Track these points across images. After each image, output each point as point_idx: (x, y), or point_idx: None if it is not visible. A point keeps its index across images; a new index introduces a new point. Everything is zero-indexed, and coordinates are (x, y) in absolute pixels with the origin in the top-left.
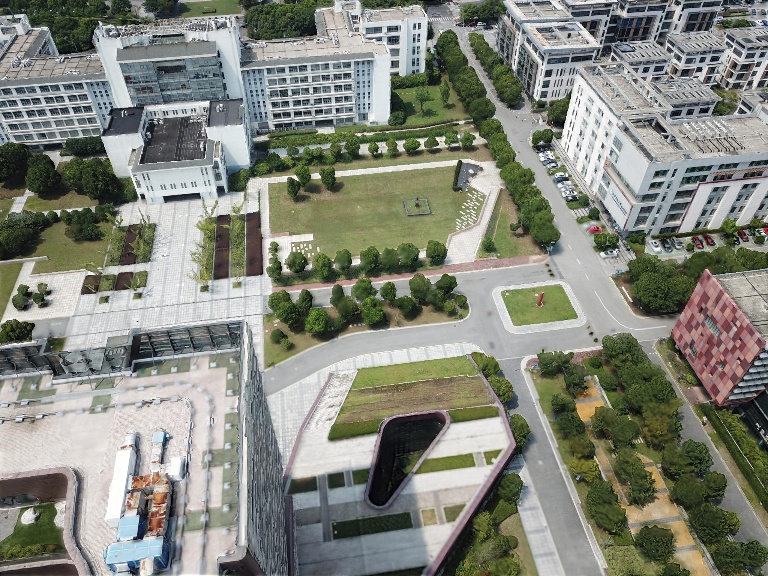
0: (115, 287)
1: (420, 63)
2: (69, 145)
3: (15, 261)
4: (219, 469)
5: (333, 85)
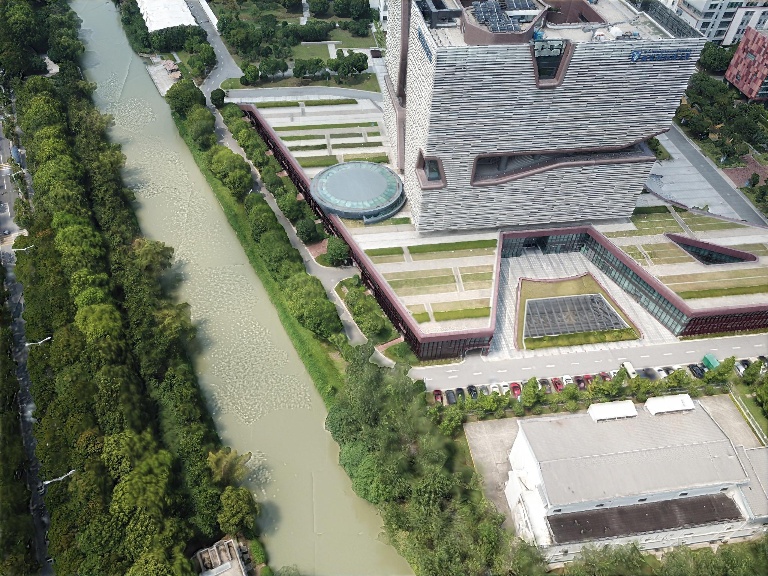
0: None
1: None
2: None
3: (323, 43)
4: None
5: None
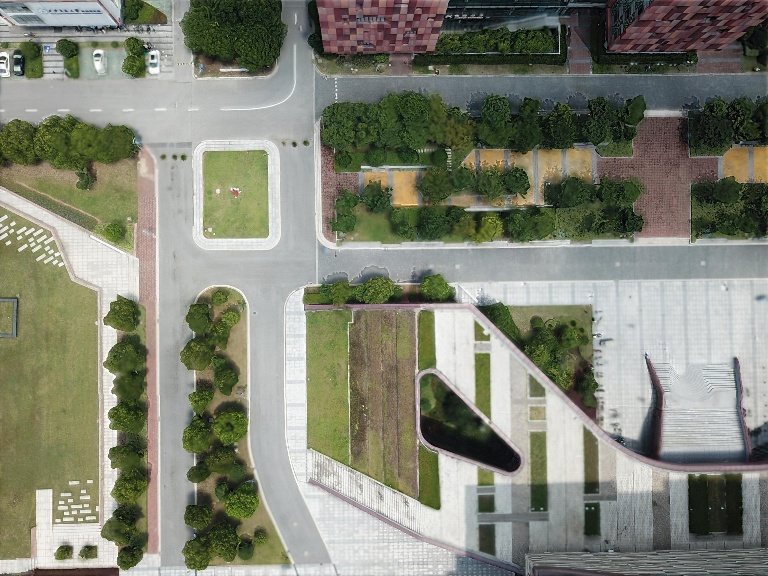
0: None
1: None
2: None
3: None
4: None
5: None
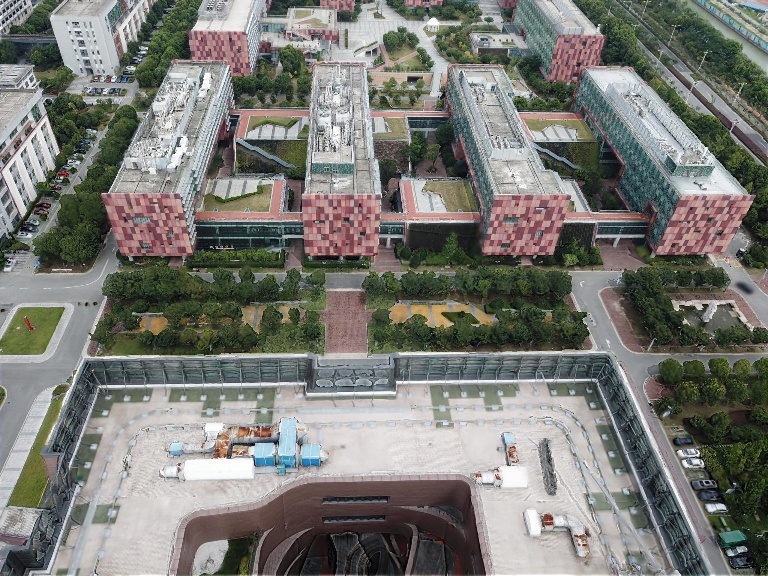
0: None
1: None
2: None
3: None
4: (223, 404)
5: None
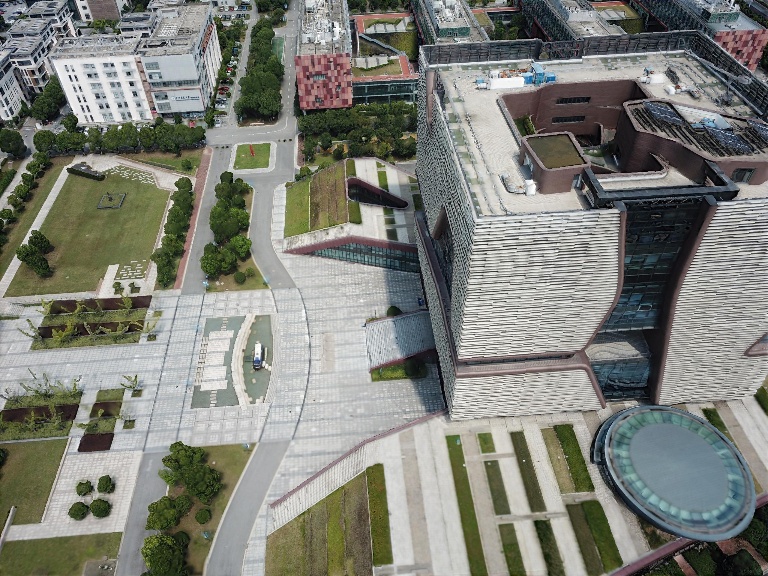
0: (114, 415)
1: None
2: None
3: None
4: None
5: None
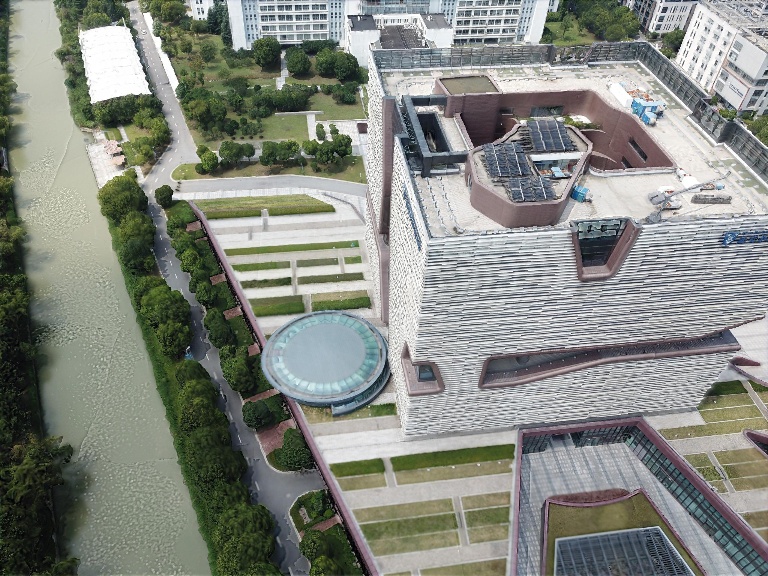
0: None
1: (554, 4)
2: (306, 44)
3: (301, 113)
4: (659, 95)
5: (506, 9)
